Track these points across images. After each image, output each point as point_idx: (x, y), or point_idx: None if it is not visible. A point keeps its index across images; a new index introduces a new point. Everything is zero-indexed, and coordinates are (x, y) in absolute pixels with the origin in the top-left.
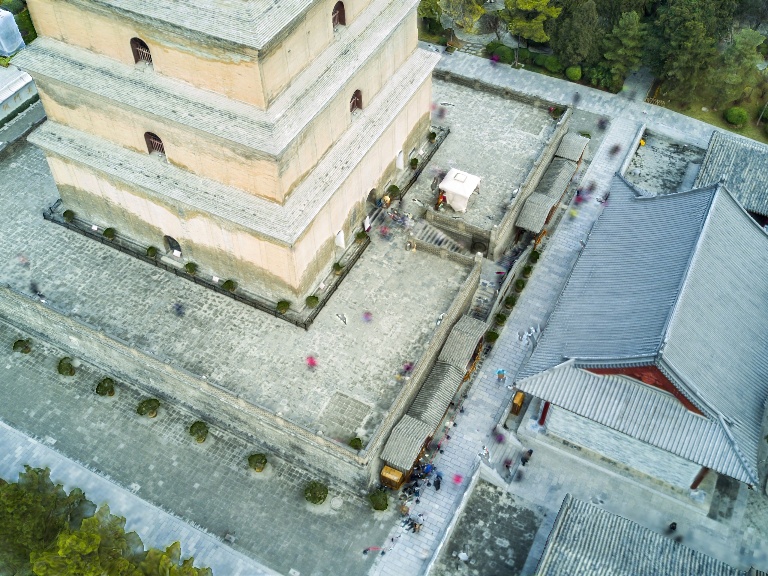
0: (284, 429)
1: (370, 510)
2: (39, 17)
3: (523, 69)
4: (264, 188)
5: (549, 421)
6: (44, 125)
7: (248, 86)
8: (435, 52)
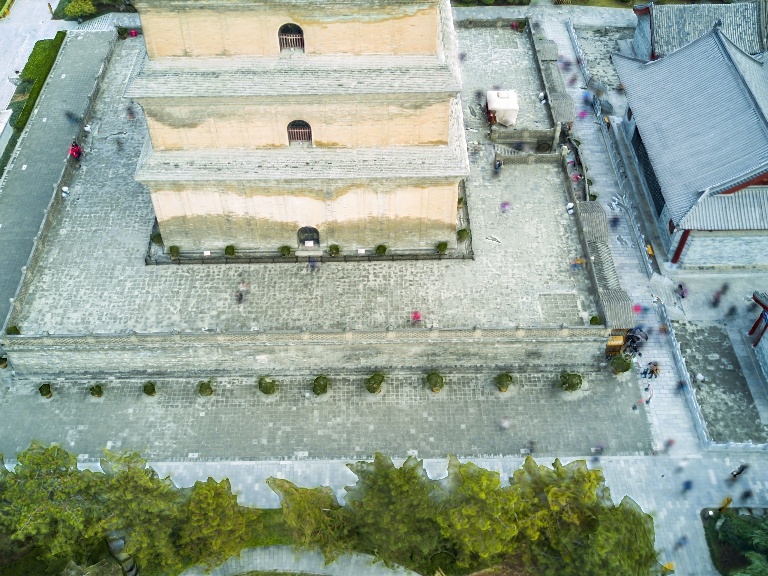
0: (524, 340)
1: (612, 378)
2: (155, 37)
3: None
4: (430, 134)
5: (687, 255)
6: (151, 158)
7: (420, 35)
8: None
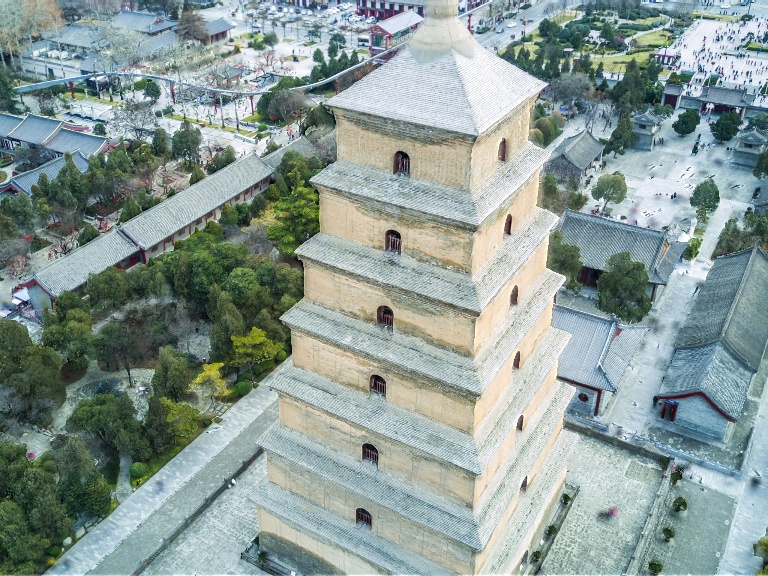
0: None
1: (677, 487)
2: None
3: (260, 383)
4: None
5: None
6: None
7: None
8: (219, 430)
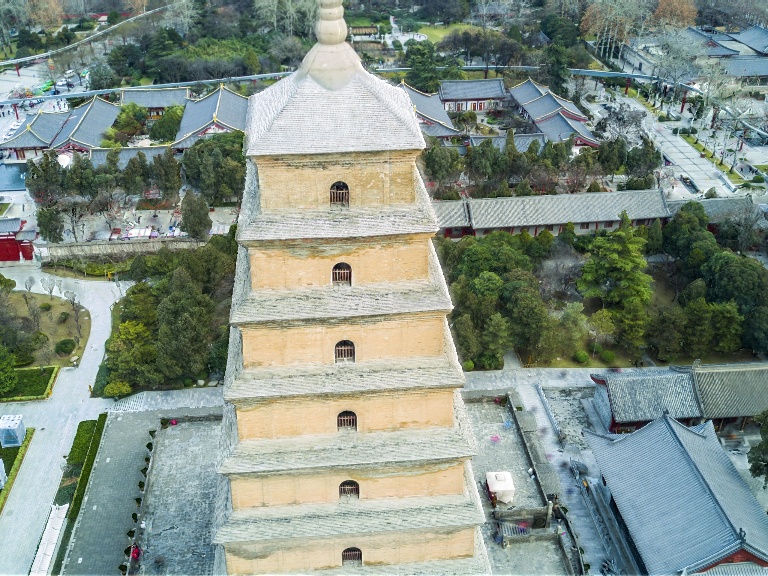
0: None
1: None
2: (240, 495)
3: None
4: (459, 550)
5: None
6: None
7: (451, 482)
8: None
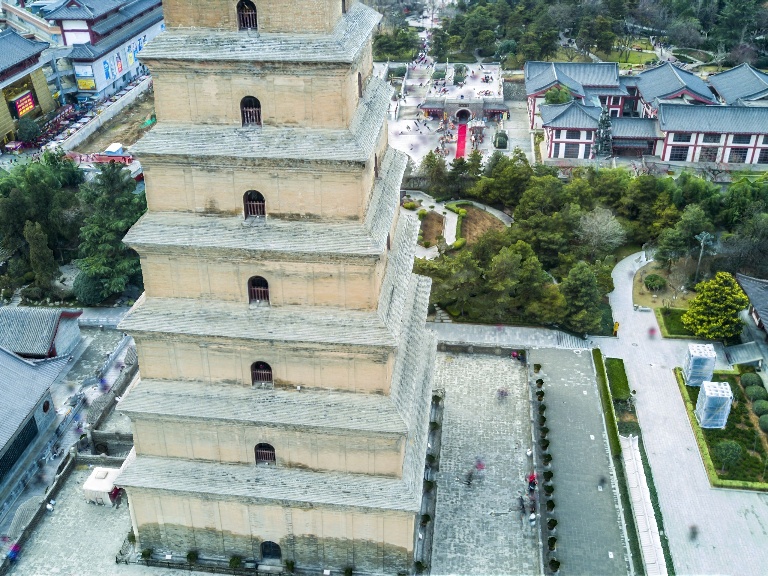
0: None
1: None
2: None
3: None
4: None
5: None
6: None
7: None
8: None
